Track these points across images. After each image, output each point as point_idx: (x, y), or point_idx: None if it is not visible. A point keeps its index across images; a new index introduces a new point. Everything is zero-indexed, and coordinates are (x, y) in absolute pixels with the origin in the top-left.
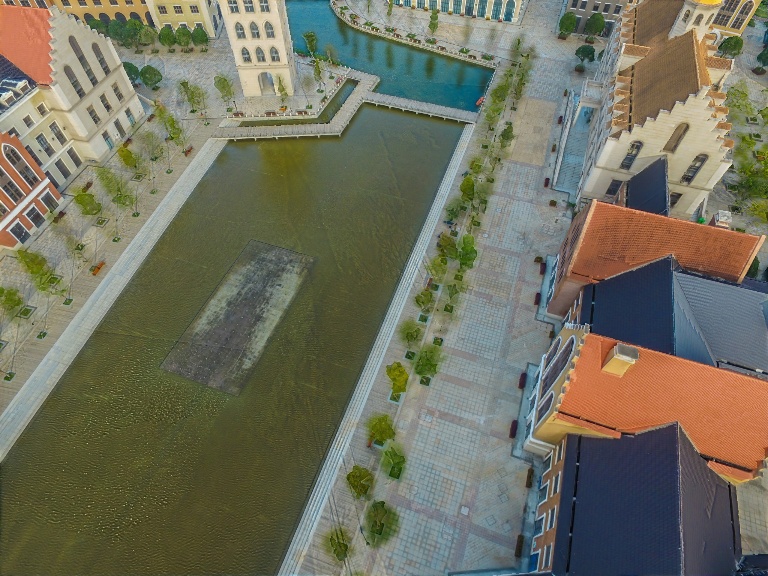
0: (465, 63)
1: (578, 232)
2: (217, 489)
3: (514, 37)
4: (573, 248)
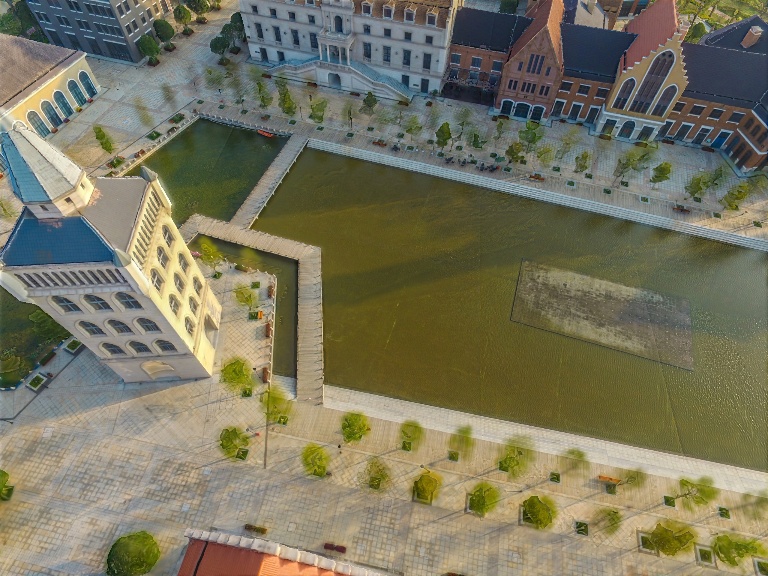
0: (177, 140)
1: (542, 56)
2: (763, 300)
3: (137, 95)
4: (549, 64)
